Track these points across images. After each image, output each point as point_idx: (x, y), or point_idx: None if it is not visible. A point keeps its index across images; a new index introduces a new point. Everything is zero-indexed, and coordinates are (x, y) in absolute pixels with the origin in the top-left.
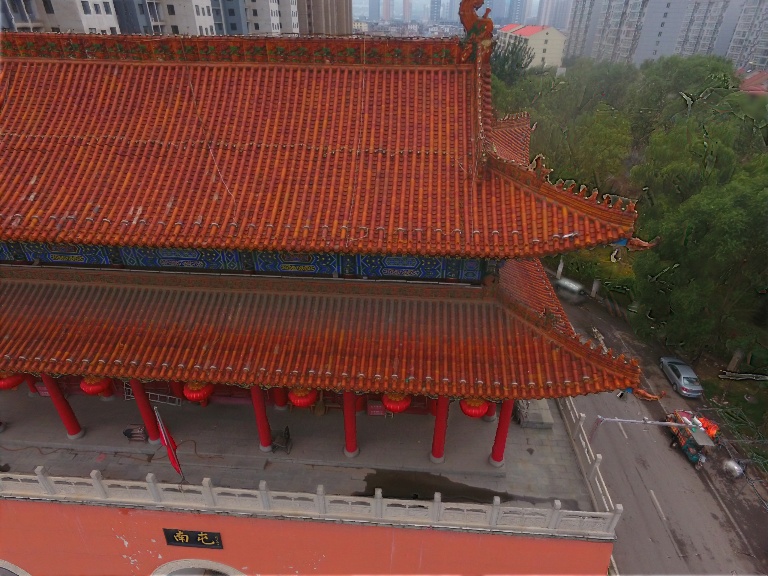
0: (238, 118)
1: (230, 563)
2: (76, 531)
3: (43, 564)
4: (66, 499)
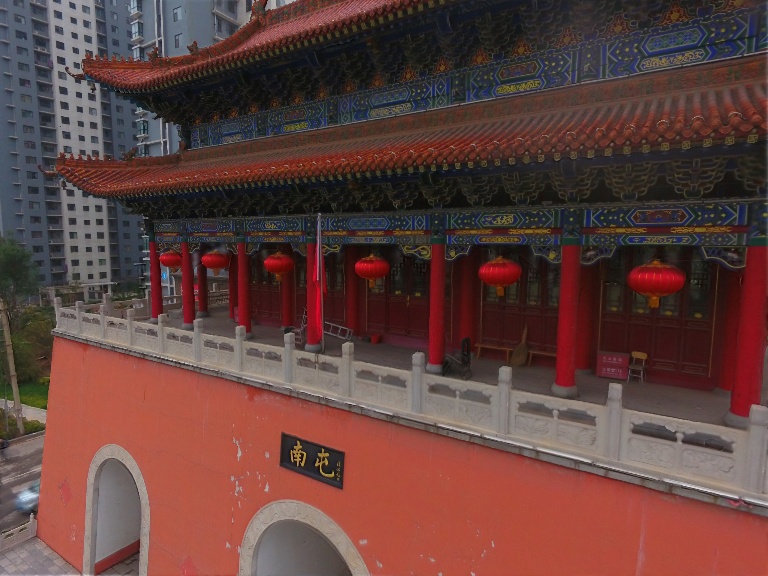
0: None
1: (346, 524)
2: (201, 423)
3: (161, 474)
4: (206, 366)
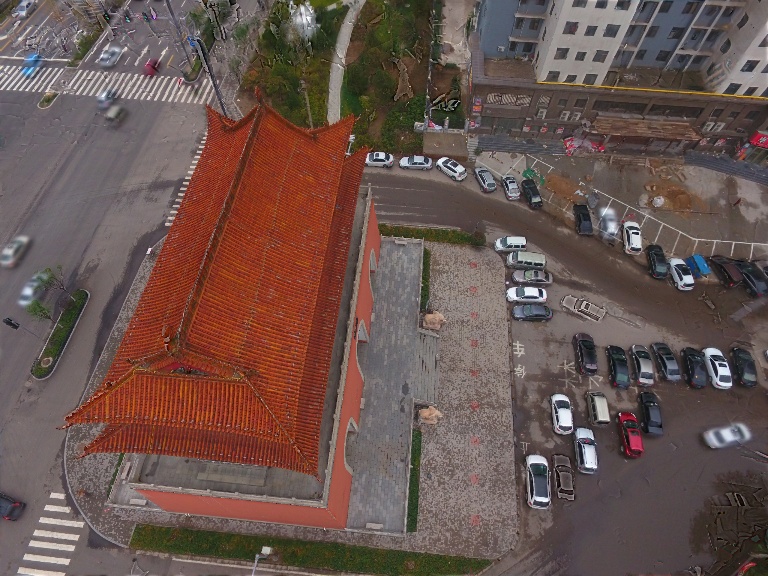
0: (202, 248)
1: None
2: None
3: None
4: None
